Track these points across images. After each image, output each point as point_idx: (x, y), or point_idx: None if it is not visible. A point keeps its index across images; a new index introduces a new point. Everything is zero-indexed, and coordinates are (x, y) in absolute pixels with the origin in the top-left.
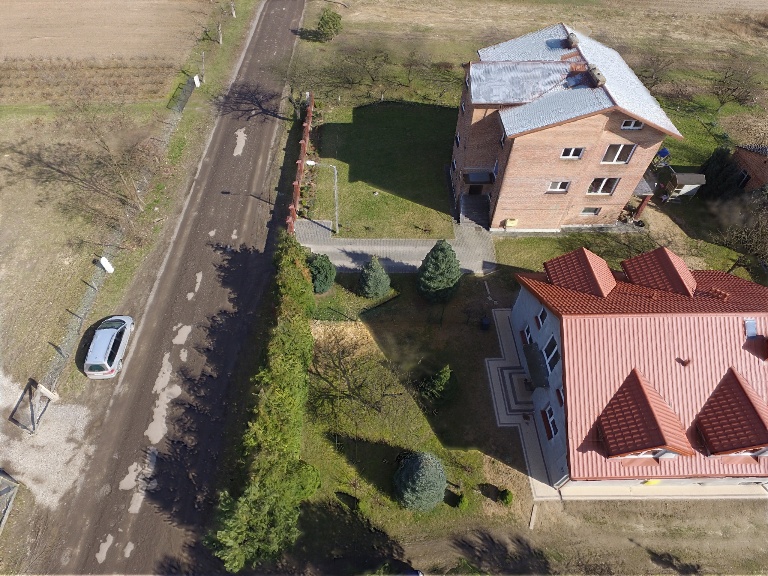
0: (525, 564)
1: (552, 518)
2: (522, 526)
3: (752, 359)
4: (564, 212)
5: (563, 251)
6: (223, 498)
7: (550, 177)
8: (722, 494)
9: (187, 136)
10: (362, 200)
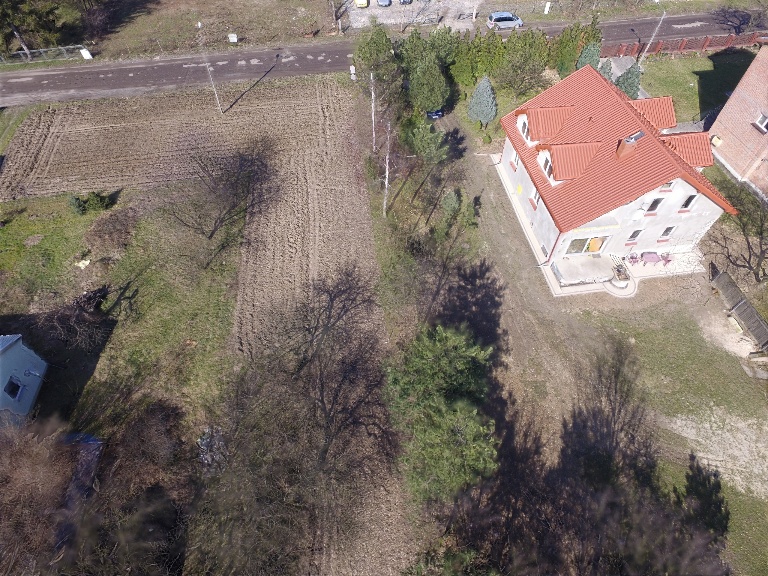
0: (457, 150)
1: (483, 161)
2: (474, 151)
3: (613, 148)
4: (753, 158)
5: (714, 182)
6: (449, 27)
7: (763, 106)
8: (530, 238)
9: (674, 7)
10: (678, 79)
